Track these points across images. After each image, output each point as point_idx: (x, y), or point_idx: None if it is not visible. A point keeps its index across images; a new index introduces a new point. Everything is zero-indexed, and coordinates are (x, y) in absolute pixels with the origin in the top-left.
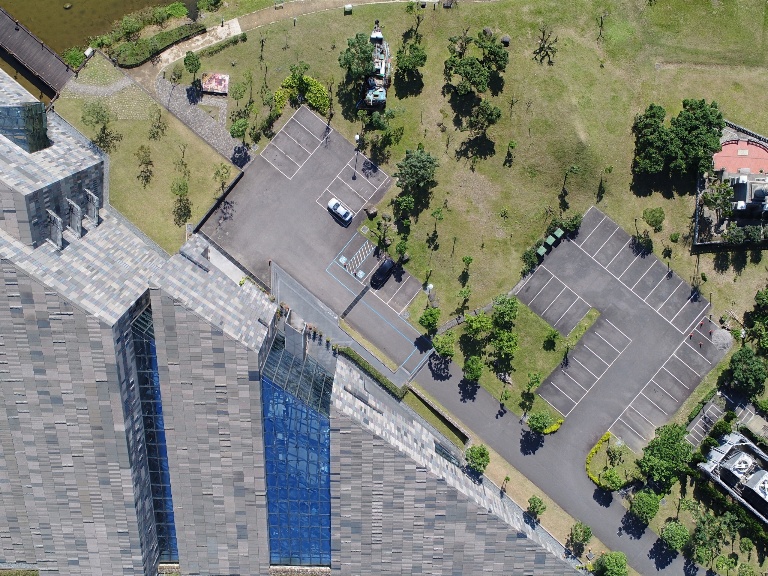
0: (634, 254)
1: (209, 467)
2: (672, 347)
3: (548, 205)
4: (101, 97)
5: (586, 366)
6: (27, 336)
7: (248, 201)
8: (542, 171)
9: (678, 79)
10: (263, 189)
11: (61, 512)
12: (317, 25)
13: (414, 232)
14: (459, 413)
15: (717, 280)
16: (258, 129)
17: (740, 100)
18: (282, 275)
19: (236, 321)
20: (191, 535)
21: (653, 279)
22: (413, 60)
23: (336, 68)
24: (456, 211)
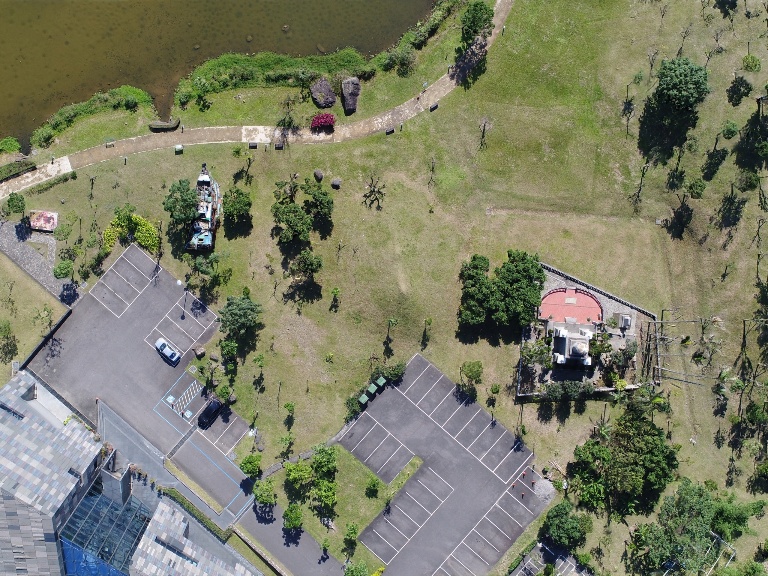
0: (458, 402)
1: None
2: (494, 497)
3: (373, 352)
4: None
5: (408, 514)
6: None
7: (76, 339)
8: (367, 318)
9: (508, 225)
10: (91, 327)
11: None
12: (148, 164)
13: (241, 374)
14: (282, 557)
15: (540, 430)
16: (87, 267)
17: (569, 248)
18: (108, 414)
19: (37, 479)
20: None
21: (476, 428)
22: (238, 205)
23: None
24: (282, 355)
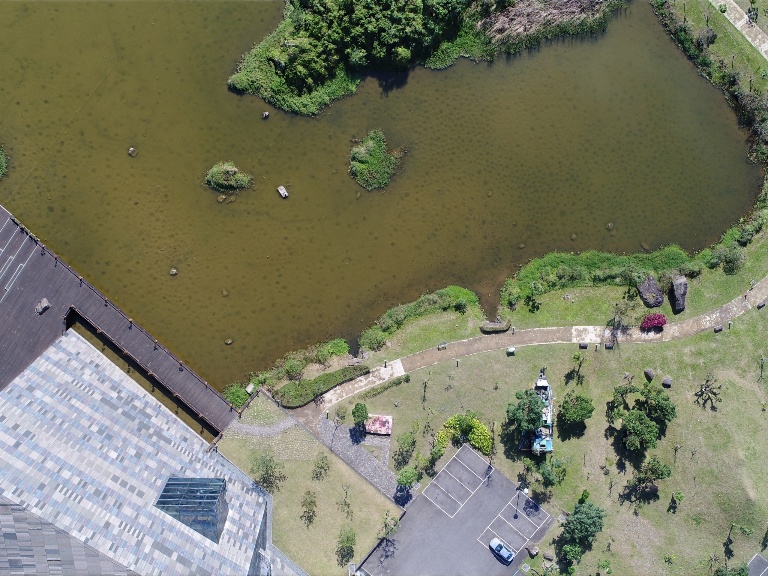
0: None
1: None
2: None
3: (713, 553)
4: (264, 437)
5: None
6: None
7: (410, 539)
8: (707, 520)
9: None
10: (425, 527)
11: None
12: (480, 366)
13: (576, 572)
14: None
15: None
16: (420, 468)
17: None
18: None
19: None
20: None
21: None
22: (580, 412)
23: (498, 409)
24: (620, 555)
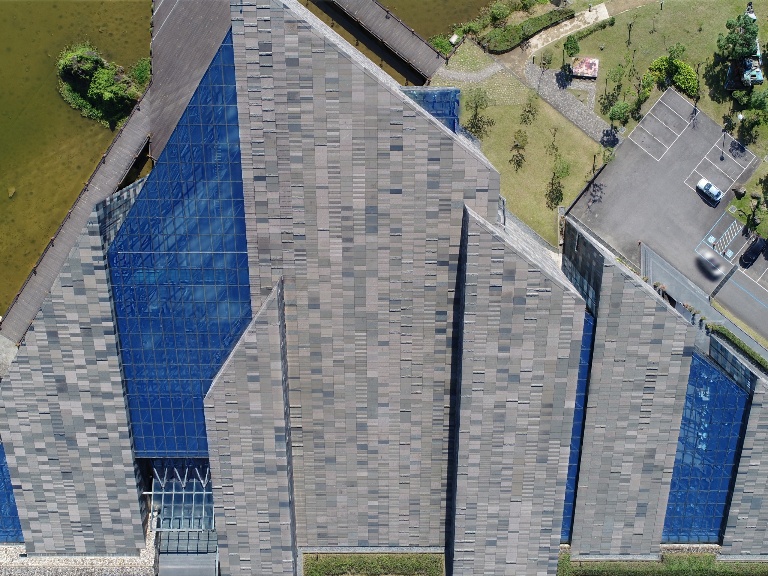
0: None
1: (623, 445)
2: None
3: None
4: (471, 83)
5: None
6: (500, 314)
7: (617, 183)
8: None
9: None
10: (631, 171)
11: (491, 491)
12: (683, 8)
13: None
14: None
15: None
16: (626, 112)
17: None
18: (653, 256)
19: (660, 298)
20: (590, 514)
21: None
22: None
23: (703, 50)
24: None
